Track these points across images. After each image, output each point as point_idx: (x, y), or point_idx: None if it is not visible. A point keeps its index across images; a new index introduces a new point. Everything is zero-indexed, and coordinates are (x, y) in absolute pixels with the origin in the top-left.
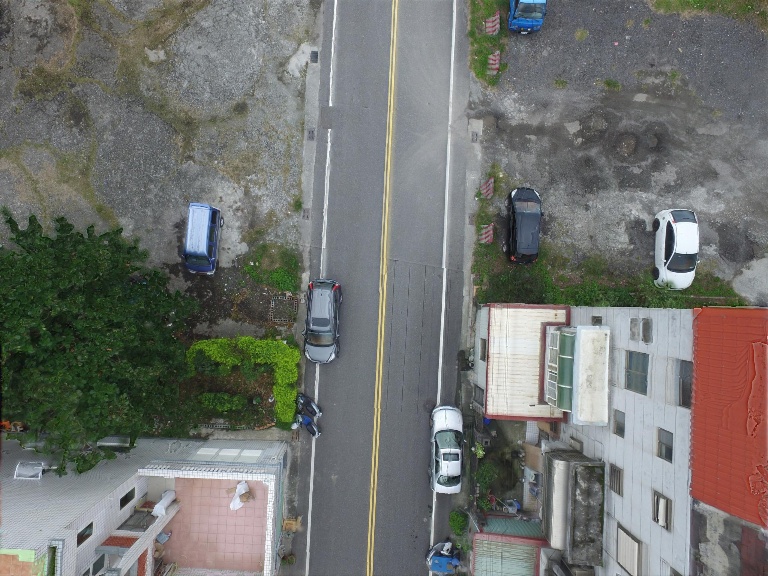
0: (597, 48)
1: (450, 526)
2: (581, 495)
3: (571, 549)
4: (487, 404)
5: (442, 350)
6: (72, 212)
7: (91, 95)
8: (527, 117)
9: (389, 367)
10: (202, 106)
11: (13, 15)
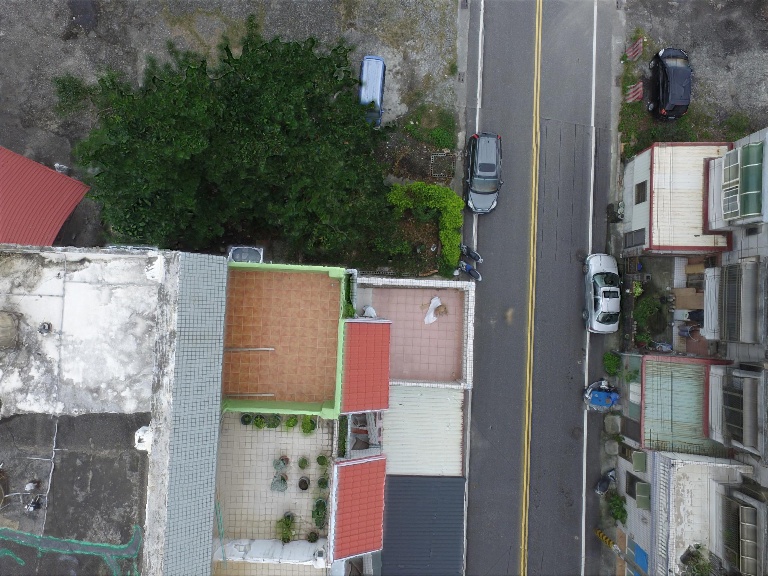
0: None
1: (606, 365)
2: None
3: (765, 336)
4: (653, 236)
5: (592, 203)
6: None
7: None
8: None
9: (543, 219)
10: None
11: None
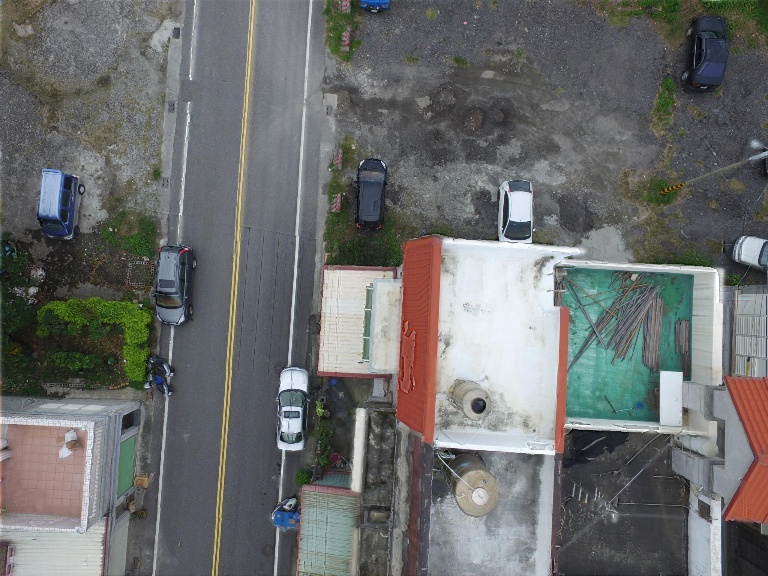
0: (447, 27)
1: None
2: (374, 439)
3: (363, 490)
4: None
5: (293, 314)
6: None
7: None
8: (379, 92)
9: (242, 330)
10: (67, 79)
11: None
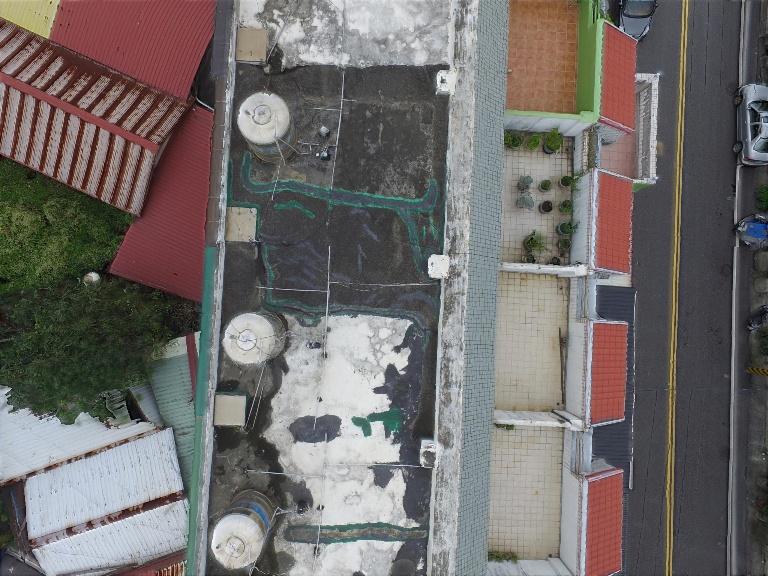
0: None
1: (758, 199)
2: None
3: None
4: None
5: (743, 36)
6: None
7: None
8: None
9: (692, 51)
10: None
11: None
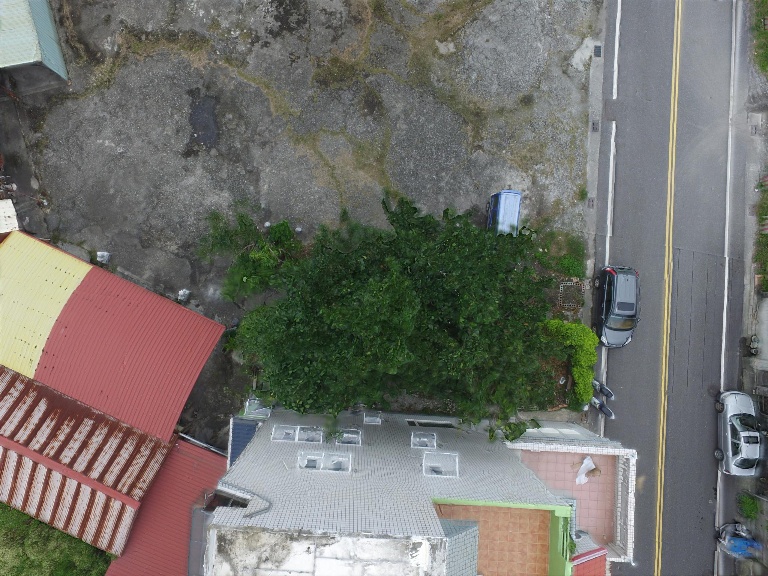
0: None
1: (739, 508)
2: None
3: None
4: None
5: (725, 337)
6: (367, 198)
7: (384, 85)
8: None
9: (674, 352)
10: (490, 97)
11: (310, 7)
